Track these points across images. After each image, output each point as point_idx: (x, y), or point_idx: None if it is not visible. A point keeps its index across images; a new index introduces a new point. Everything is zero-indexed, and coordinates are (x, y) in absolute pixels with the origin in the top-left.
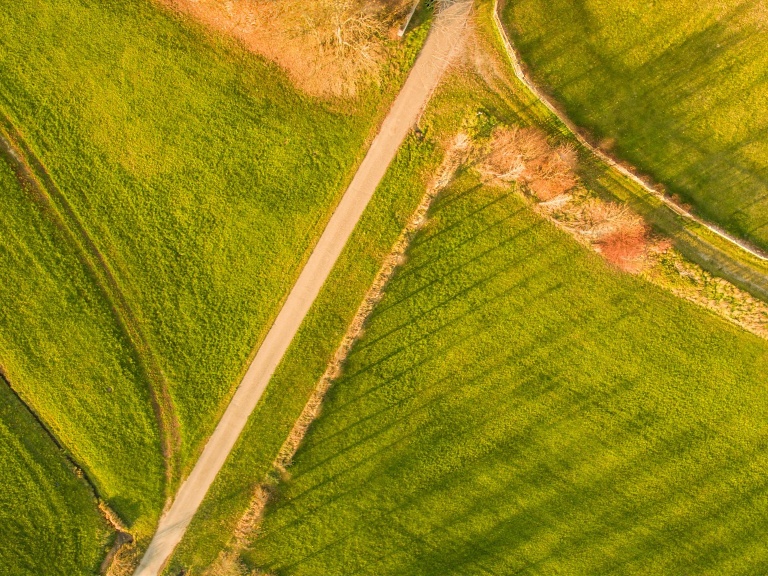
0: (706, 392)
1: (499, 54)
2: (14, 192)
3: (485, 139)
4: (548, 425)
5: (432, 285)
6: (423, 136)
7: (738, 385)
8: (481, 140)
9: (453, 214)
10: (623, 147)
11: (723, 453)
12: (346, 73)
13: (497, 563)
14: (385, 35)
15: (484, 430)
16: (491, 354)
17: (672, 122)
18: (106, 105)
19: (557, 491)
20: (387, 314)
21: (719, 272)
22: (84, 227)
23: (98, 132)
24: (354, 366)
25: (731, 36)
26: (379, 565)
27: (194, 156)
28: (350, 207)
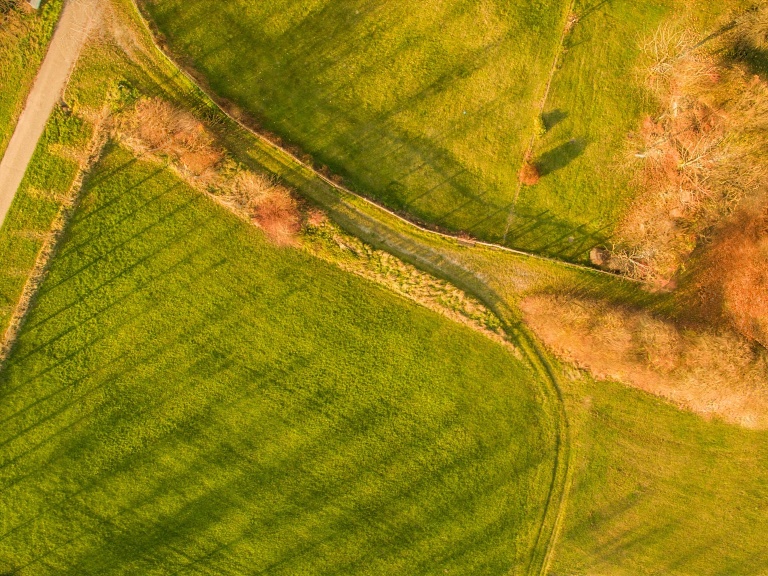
0: (384, 368)
1: (137, 25)
2: None
3: (130, 112)
4: (227, 404)
5: (96, 263)
6: (70, 111)
7: (416, 360)
8: (125, 113)
9: (110, 190)
10: (270, 118)
11: (408, 430)
12: None
13: (189, 545)
14: (21, 8)
15: (163, 410)
16: (163, 332)
17: (318, 91)
18: None
19: (243, 471)
20: (54, 293)
21: (381, 245)
22: None
23: None
24: (26, 346)
25: (368, 2)
26: (68, 548)
27: None
28: (4, 184)
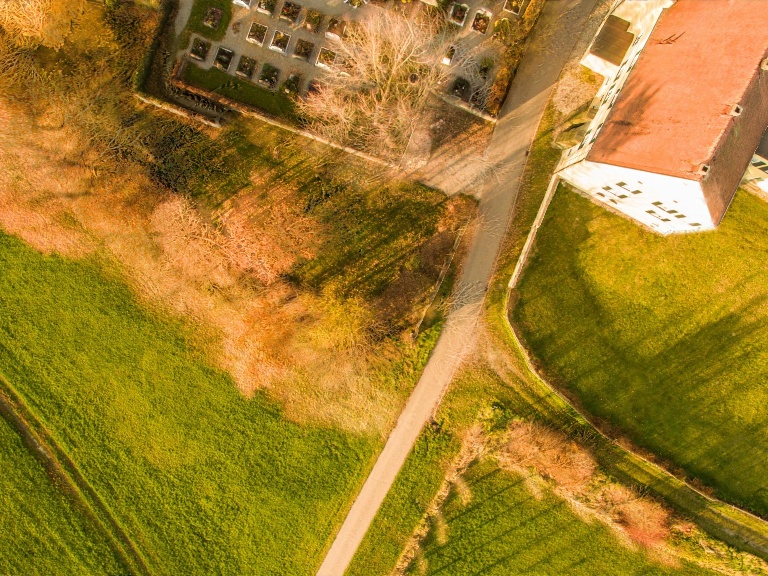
0: None
1: (511, 350)
2: (45, 487)
3: (501, 430)
4: None
5: (455, 563)
6: (439, 427)
7: None
8: (497, 433)
9: (473, 497)
10: (641, 433)
11: None
12: (360, 370)
13: None
14: (397, 336)
15: None
16: None
17: (690, 408)
18: (129, 404)
19: None
20: None
21: (745, 546)
22: (113, 516)
23: (122, 428)
24: None
25: (746, 325)
26: None
27: (216, 449)
28: (370, 495)
